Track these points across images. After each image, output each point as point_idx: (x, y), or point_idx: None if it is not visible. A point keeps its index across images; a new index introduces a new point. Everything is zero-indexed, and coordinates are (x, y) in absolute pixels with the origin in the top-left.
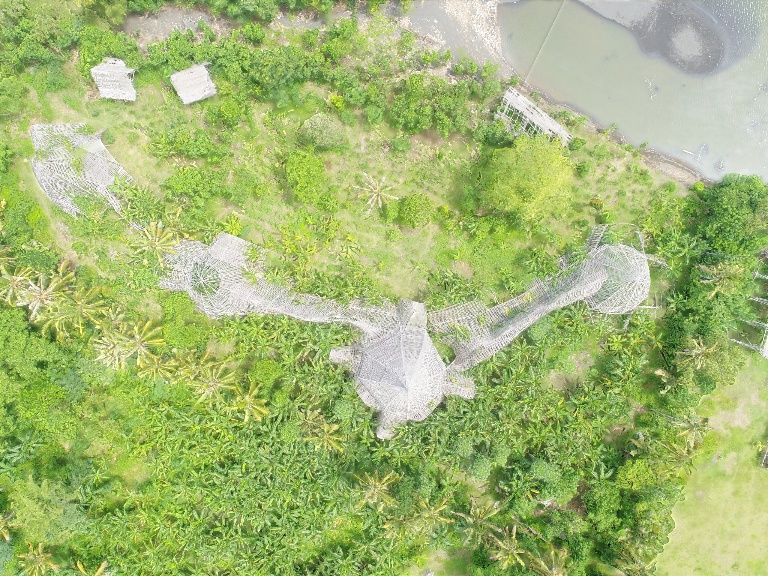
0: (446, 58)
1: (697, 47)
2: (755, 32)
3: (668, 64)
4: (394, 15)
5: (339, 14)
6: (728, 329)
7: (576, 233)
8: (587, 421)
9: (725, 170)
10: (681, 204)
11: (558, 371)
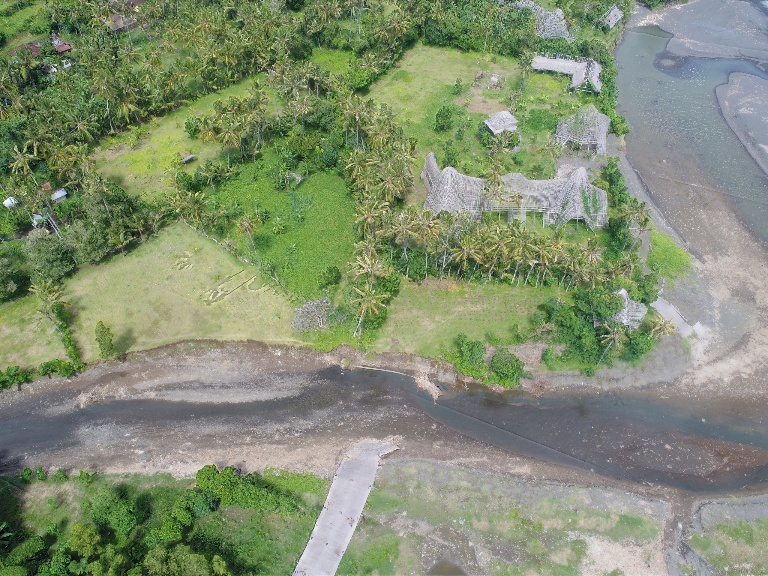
0: (627, 3)
1: None
2: (684, 78)
3: None
4: (639, 5)
5: None
6: None
7: None
8: None
9: None
10: None
11: None
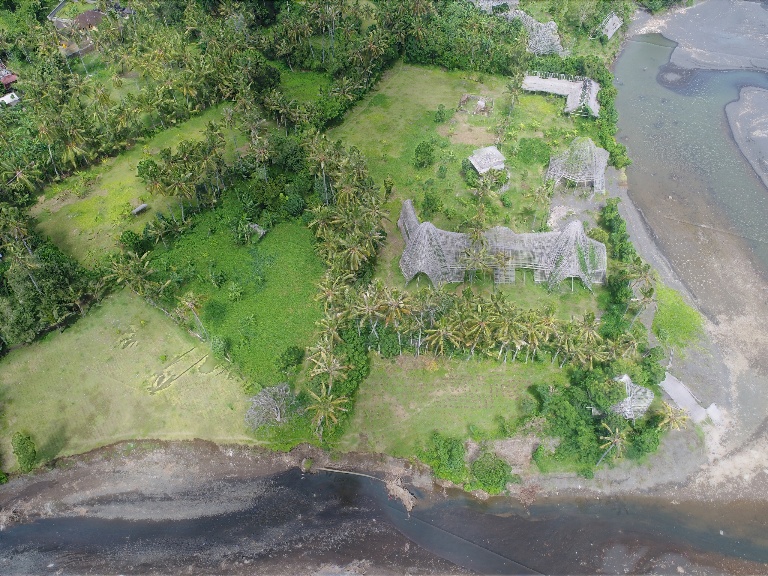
0: None
1: (672, 79)
2: (690, 95)
3: None
4: None
5: (633, 0)
6: None
7: None
8: None
9: None
10: None
11: None
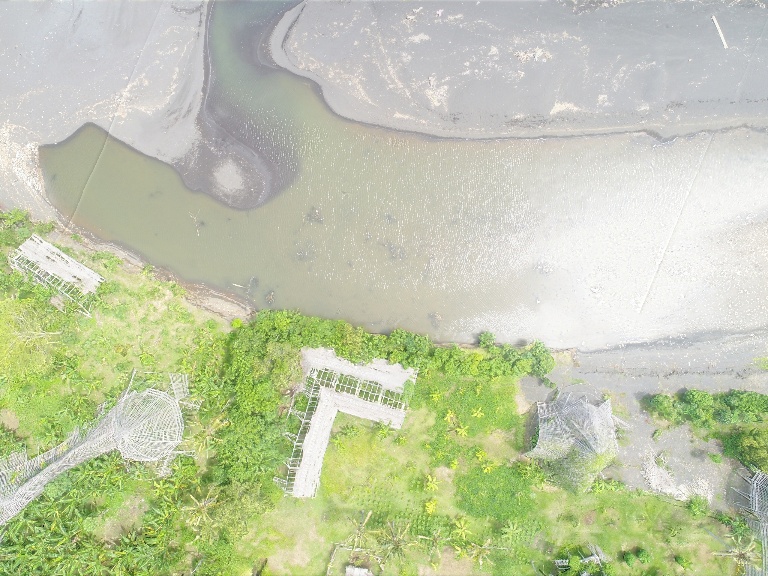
0: None
1: (239, 181)
2: (296, 164)
3: (212, 199)
4: None
5: None
6: (265, 470)
7: (122, 375)
8: (127, 574)
9: (276, 301)
10: (219, 342)
11: (113, 518)
